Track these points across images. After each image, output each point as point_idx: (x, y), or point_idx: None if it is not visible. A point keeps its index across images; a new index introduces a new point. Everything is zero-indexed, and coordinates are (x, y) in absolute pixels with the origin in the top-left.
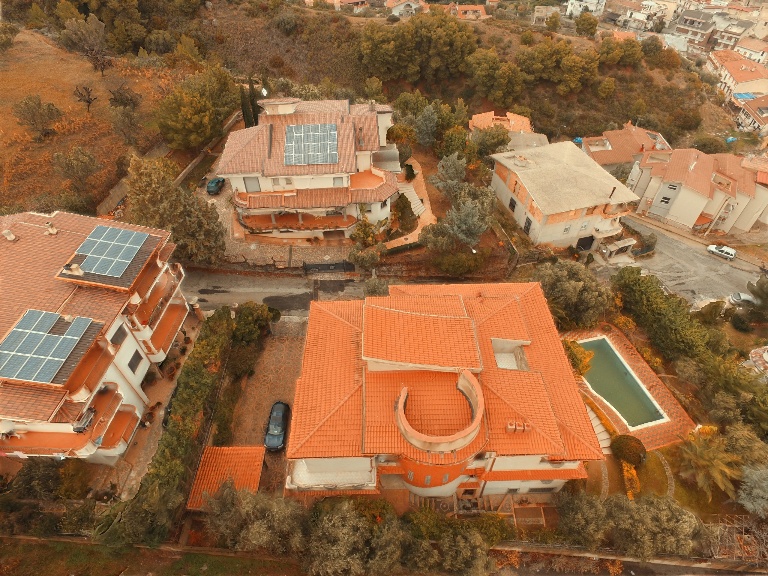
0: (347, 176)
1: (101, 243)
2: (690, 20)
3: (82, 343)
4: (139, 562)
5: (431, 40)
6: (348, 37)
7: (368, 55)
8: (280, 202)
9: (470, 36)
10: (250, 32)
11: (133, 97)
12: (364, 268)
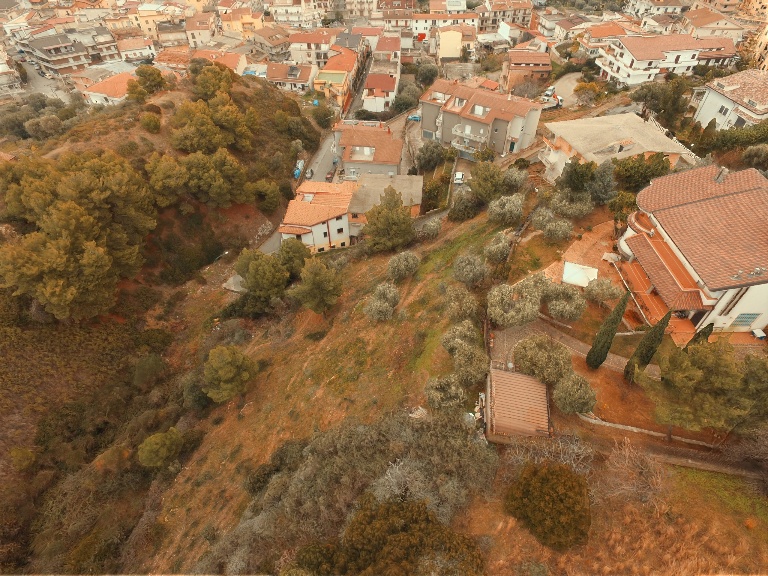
0: None
1: None
2: (53, 49)
3: None
4: None
5: (108, 200)
6: None
7: (74, 297)
8: None
9: None
10: None
11: None
12: None
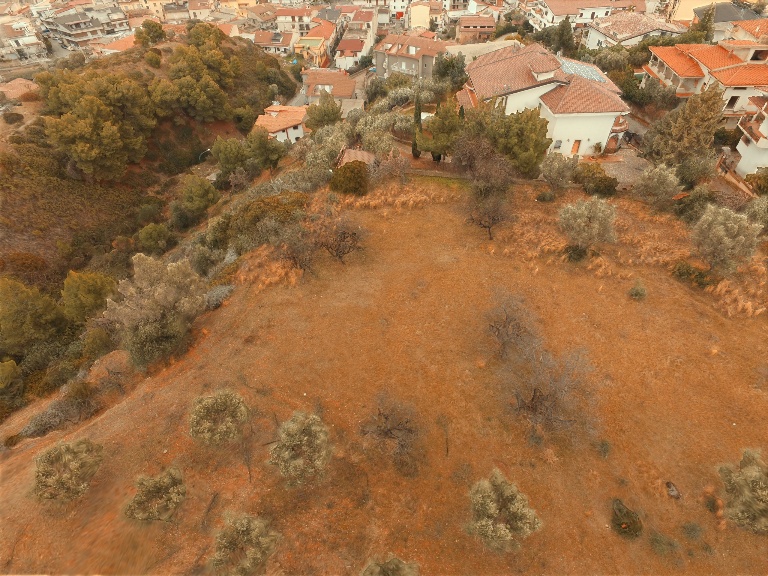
0: None
1: None
2: (74, 24)
3: None
4: None
5: (120, 102)
6: (7, 170)
7: (96, 157)
8: None
9: None
10: None
11: None
12: None
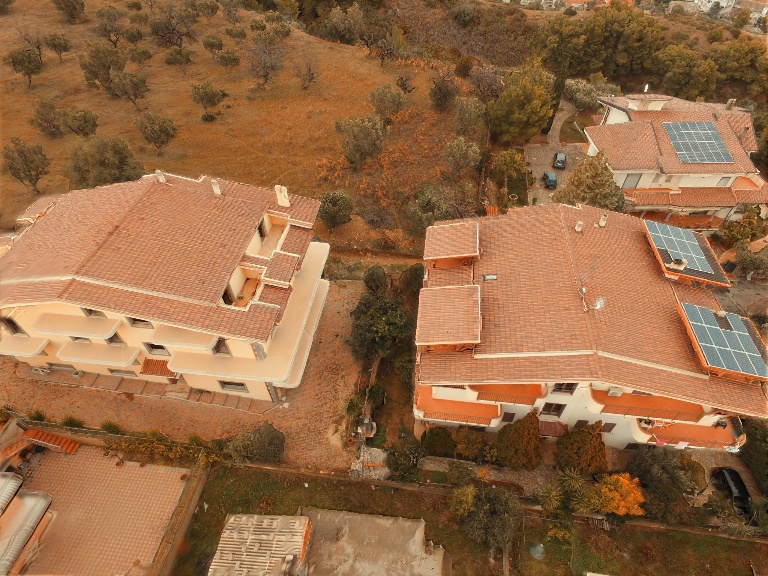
0: (737, 176)
1: (665, 238)
2: None
3: (753, 339)
4: (758, 557)
5: (620, 35)
6: (524, 30)
7: (554, 49)
8: (667, 200)
9: (657, 32)
10: (430, 23)
11: (456, 88)
12: (743, 270)
